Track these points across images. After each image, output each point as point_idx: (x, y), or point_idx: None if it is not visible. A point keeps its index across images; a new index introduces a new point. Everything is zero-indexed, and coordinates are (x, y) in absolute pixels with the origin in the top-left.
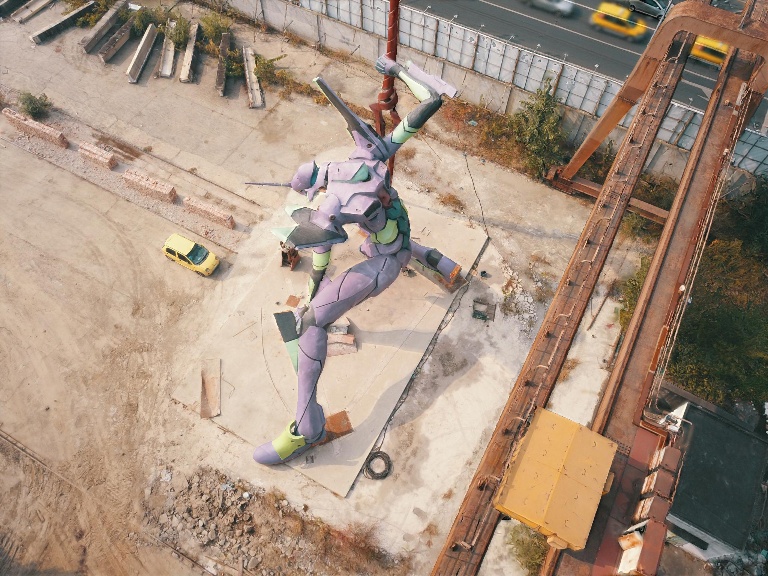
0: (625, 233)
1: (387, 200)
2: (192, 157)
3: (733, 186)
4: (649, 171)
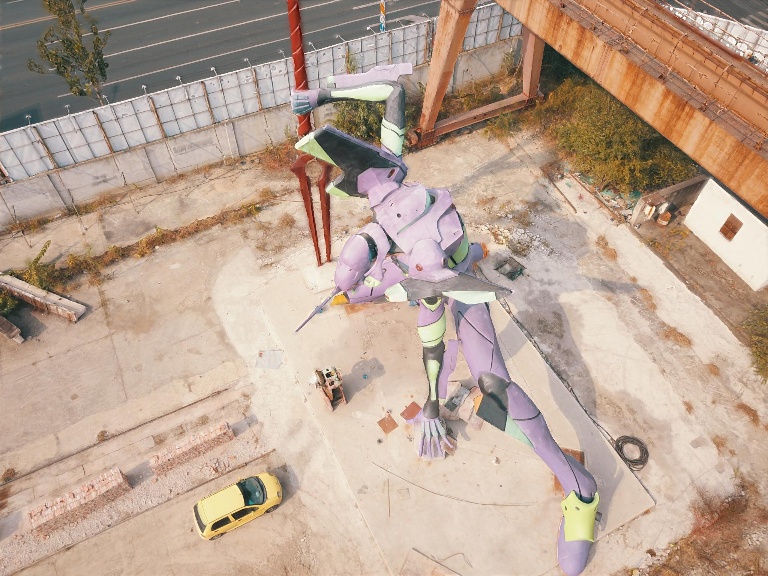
0: (503, 135)
1: (454, 207)
2: (80, 426)
3: (516, 54)
4: (454, 89)
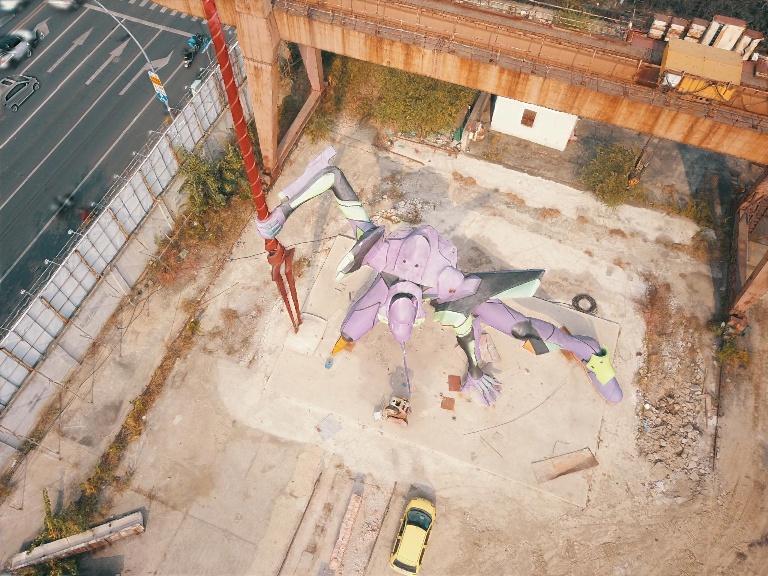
0: (325, 134)
1: None
2: None
3: None
4: (250, 115)
